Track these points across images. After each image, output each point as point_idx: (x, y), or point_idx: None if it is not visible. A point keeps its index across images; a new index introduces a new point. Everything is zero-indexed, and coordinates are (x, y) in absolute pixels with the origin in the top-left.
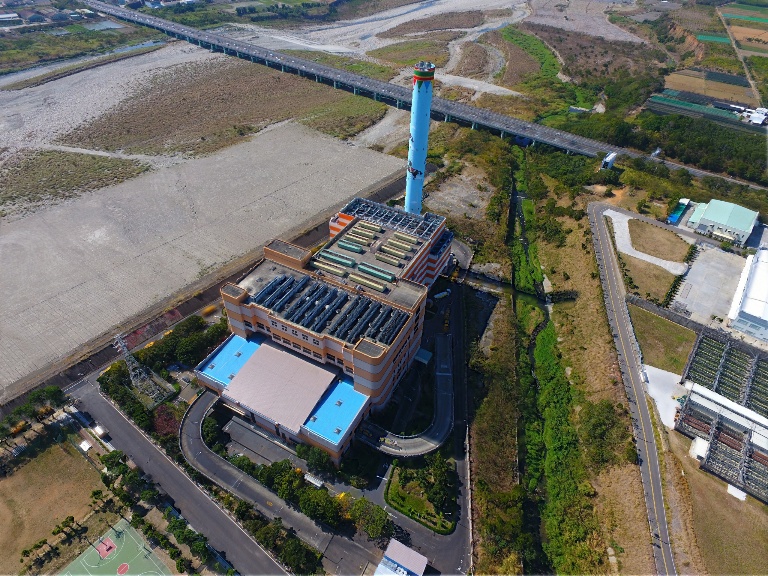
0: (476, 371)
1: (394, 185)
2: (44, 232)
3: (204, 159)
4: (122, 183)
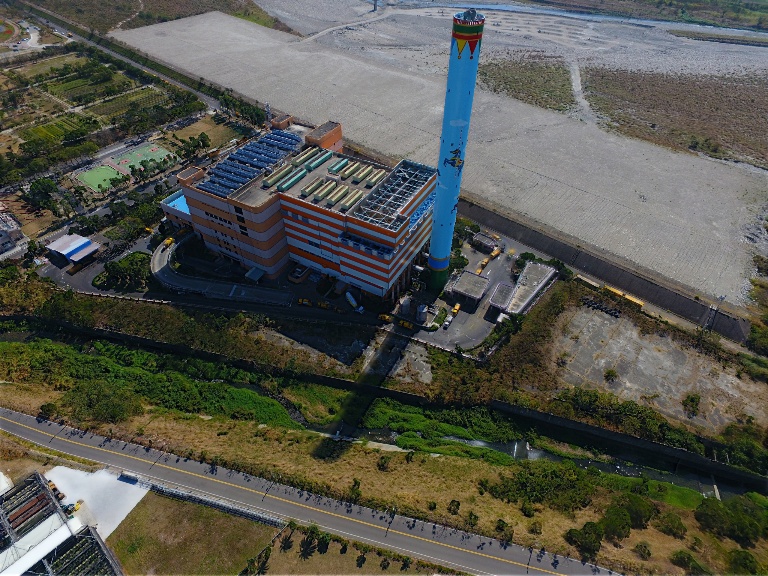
0: None
1: (619, 272)
2: (441, 92)
3: (601, 131)
4: (525, 103)
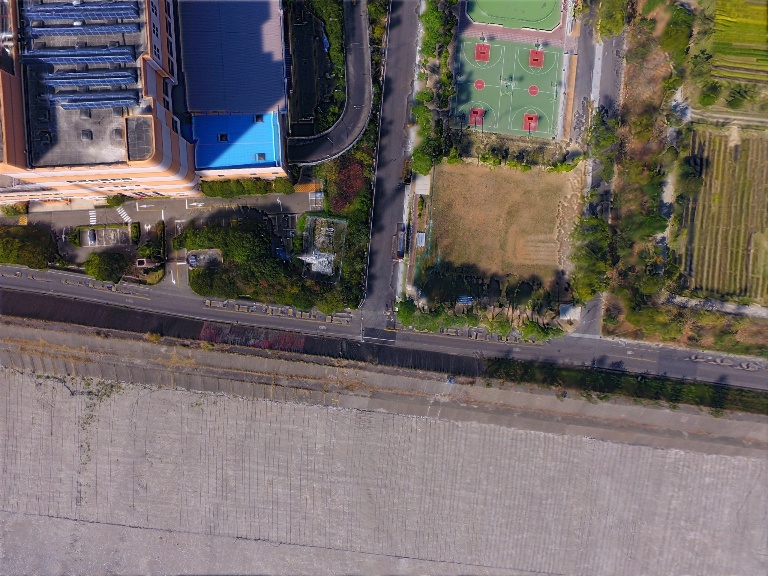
0: None
1: None
2: None
3: None
4: None
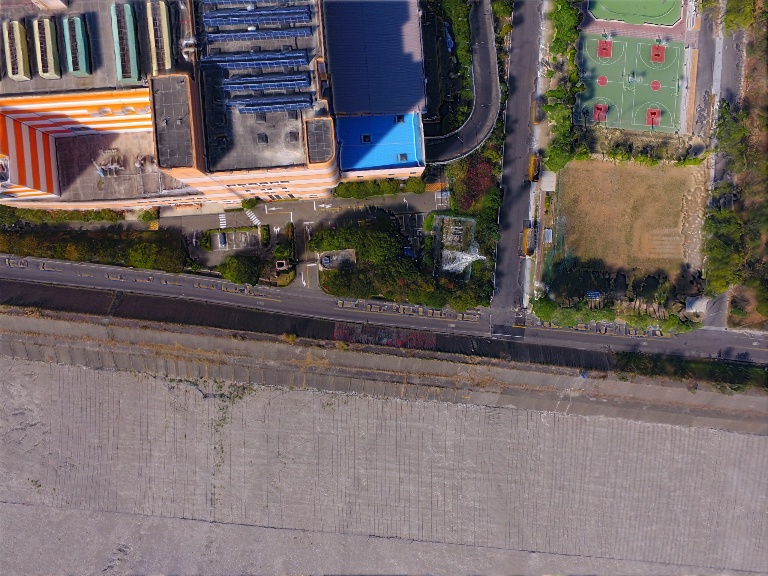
0: None
1: None
2: None
3: None
4: None
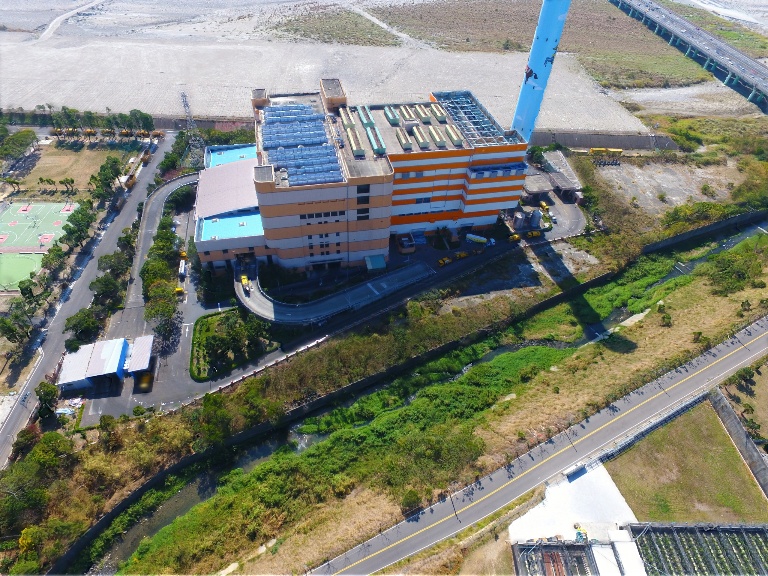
0: (407, 312)
1: (588, 137)
2: (283, 53)
3: (445, 52)
4: None
